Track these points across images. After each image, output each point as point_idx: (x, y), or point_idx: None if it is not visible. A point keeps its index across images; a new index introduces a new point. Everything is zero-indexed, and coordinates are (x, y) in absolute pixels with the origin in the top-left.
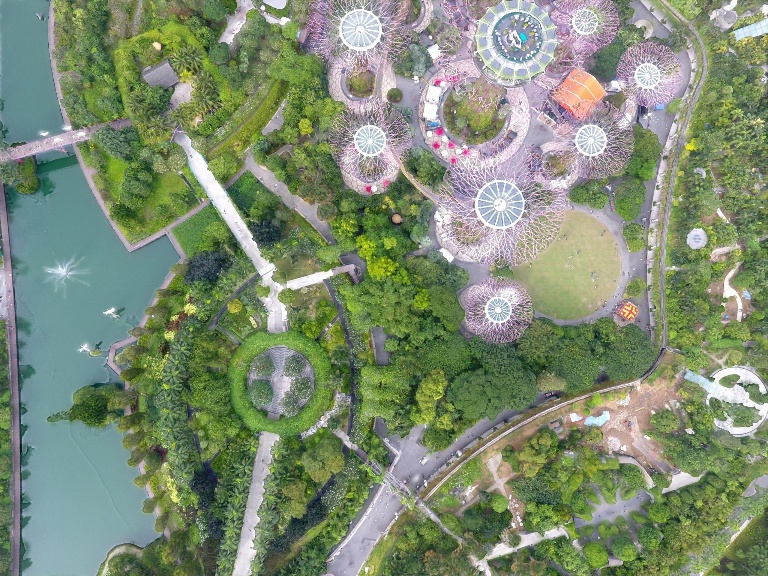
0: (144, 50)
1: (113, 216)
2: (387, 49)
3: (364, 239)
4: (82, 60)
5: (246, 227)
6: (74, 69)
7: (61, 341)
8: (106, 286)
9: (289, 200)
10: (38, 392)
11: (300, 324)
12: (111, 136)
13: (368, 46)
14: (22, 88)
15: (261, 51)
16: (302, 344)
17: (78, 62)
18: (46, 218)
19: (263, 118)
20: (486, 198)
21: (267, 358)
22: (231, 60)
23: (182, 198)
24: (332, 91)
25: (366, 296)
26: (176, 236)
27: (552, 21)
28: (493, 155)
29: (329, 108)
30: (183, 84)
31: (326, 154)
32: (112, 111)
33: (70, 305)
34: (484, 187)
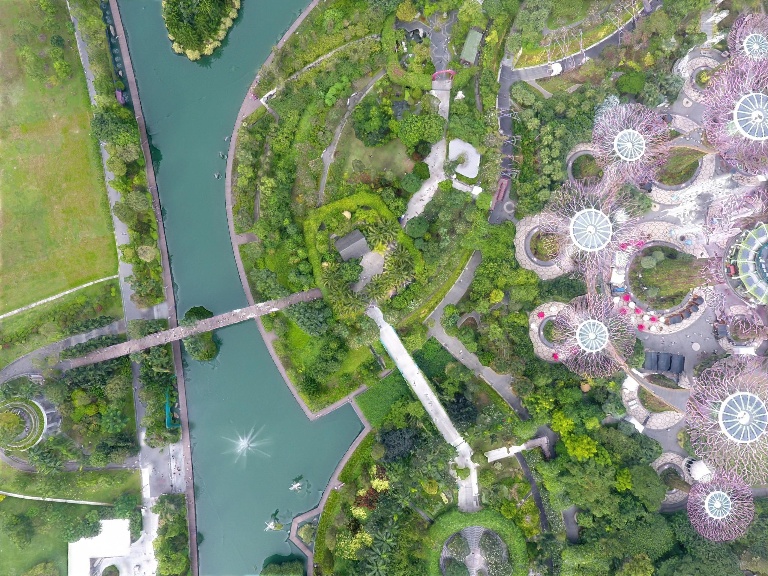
0: (340, 224)
1: (312, 399)
2: (617, 249)
3: (563, 417)
4: (275, 233)
5: (436, 399)
6: (261, 238)
7: (233, 507)
8: (284, 454)
9: (474, 367)
10: (206, 559)
11: (499, 506)
12: (311, 317)
13: (599, 247)
14: (191, 243)
15: (456, 223)
16: (499, 524)
17: (269, 234)
18: (224, 385)
19: (449, 284)
20: (731, 412)
21: (465, 541)
22: (427, 233)
23: (367, 367)
24: (516, 254)
25: (568, 478)
26: (360, 405)
27: (733, 183)
28: (737, 367)
29: (522, 279)
30: (371, 252)
31: (519, 326)
32: (304, 285)
33: (247, 475)
34: (728, 400)
